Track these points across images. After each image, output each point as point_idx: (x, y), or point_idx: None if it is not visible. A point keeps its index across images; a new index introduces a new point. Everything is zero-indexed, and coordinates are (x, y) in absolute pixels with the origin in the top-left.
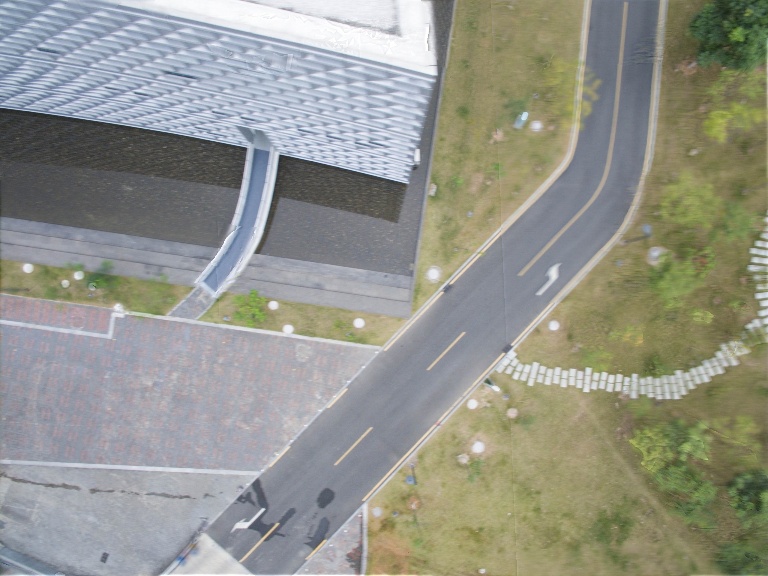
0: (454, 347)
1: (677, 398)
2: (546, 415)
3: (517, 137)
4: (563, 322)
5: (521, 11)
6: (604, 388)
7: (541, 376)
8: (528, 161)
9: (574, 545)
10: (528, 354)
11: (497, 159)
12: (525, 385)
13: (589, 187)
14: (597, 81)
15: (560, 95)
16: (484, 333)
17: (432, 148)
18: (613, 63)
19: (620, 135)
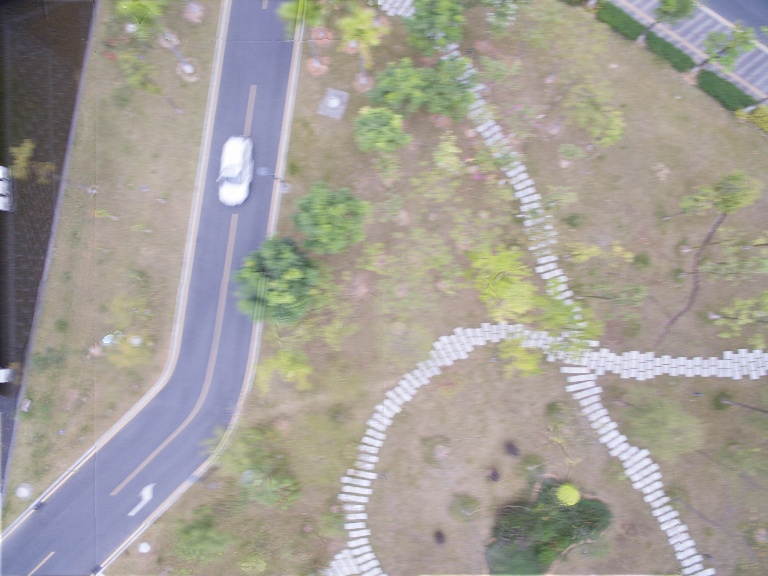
0: (43, 567)
1: None
2: None
3: (115, 352)
4: (153, 545)
5: (125, 222)
6: None
7: None
8: (125, 377)
9: None
10: None
11: (93, 375)
12: None
13: (185, 406)
14: (200, 296)
15: (161, 310)
16: (73, 553)
17: (25, 363)
18: (217, 278)
19: (223, 352)
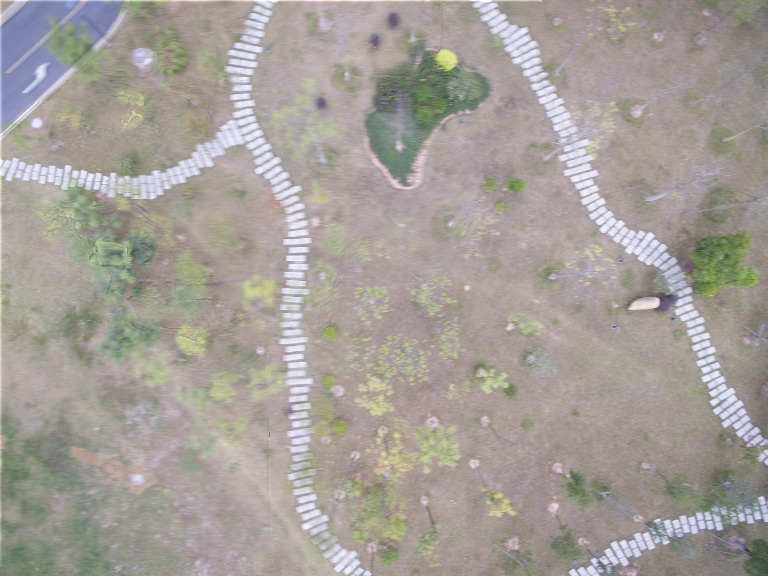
0: None
1: (152, 198)
2: (22, 210)
3: None
4: (45, 120)
5: None
6: (82, 186)
7: (20, 172)
8: None
9: (39, 339)
10: (8, 150)
11: None
12: (3, 180)
13: None
14: None
15: None
16: None
17: None
18: None
19: None
